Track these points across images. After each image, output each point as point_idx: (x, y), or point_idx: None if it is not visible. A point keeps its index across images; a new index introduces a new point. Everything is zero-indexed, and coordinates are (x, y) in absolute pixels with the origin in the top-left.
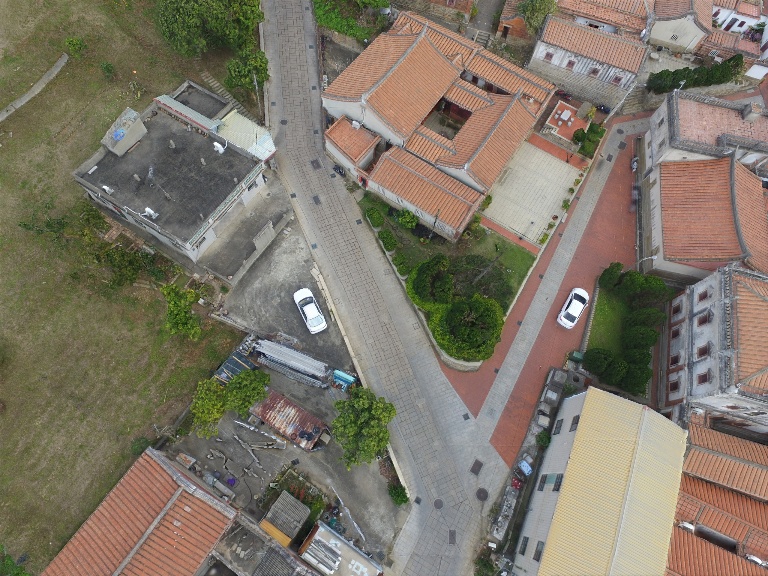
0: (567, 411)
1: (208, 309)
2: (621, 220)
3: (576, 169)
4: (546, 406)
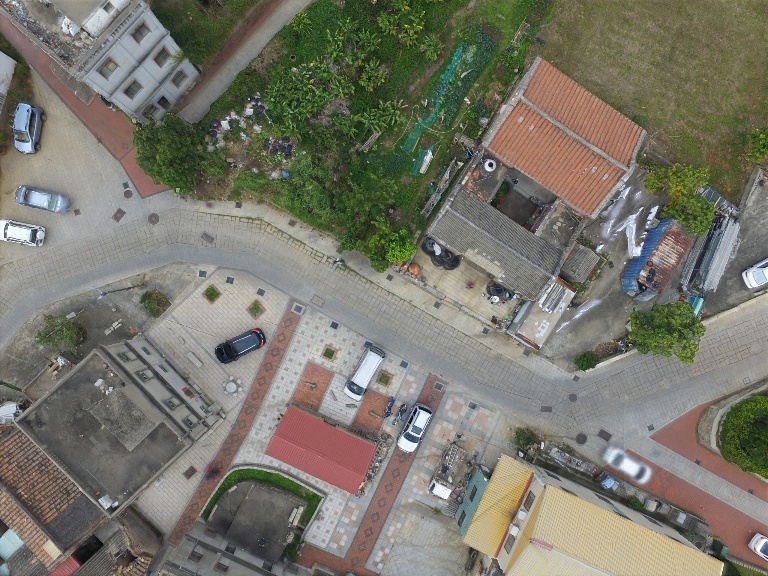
0: None
1: (765, 164)
2: None
3: None
4: (666, 510)
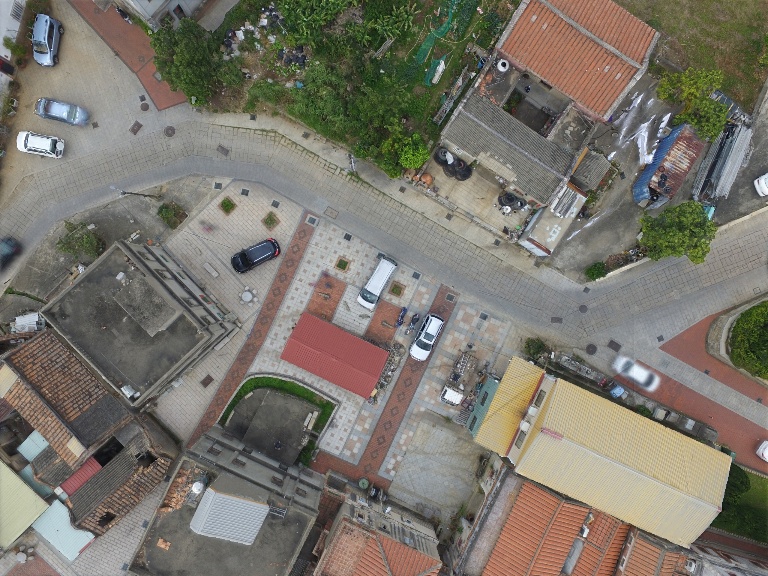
0: None
1: None
2: None
3: None
4: (675, 418)
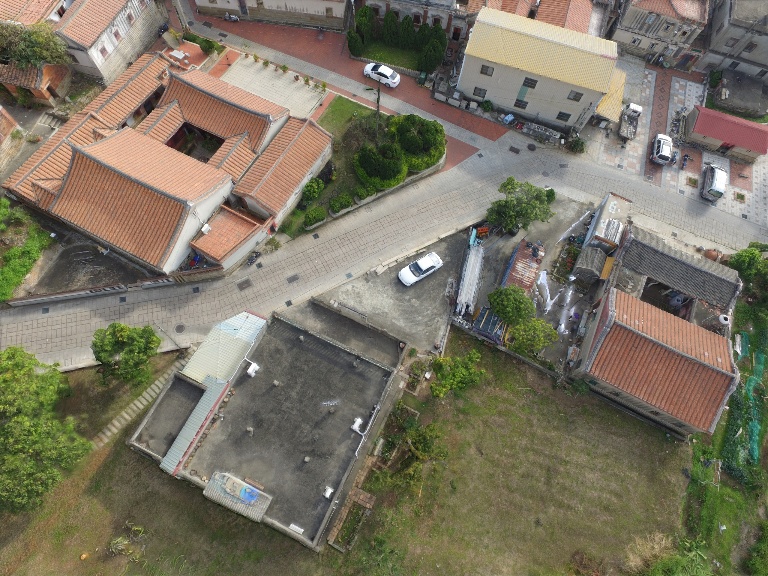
0: (471, 83)
1: None
2: (292, 36)
3: (239, 59)
4: (463, 102)
